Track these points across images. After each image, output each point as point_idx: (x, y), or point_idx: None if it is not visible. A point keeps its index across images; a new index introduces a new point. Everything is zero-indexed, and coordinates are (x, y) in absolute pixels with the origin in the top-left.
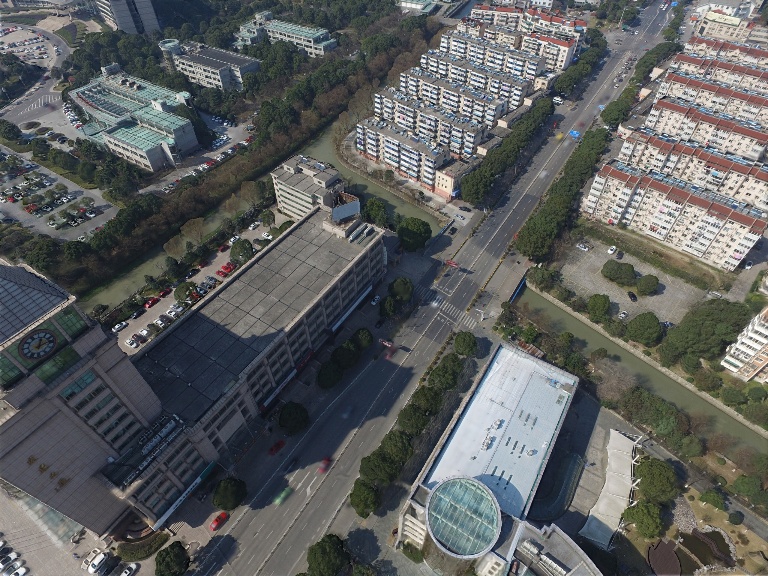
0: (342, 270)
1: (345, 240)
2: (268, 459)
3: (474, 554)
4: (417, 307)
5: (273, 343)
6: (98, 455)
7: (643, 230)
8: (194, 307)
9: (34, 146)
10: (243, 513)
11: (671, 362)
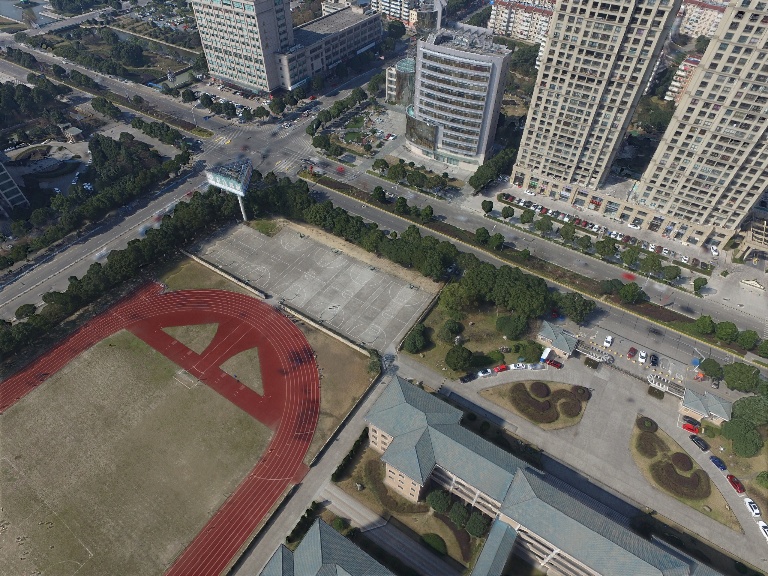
0: (362, 20)
1: (363, 15)
2: (331, 88)
3: (412, 71)
4: (397, 56)
5: (334, 33)
6: (276, 44)
7: (518, 36)
8: (298, 26)
9: (179, 2)
10: (323, 97)
11: (513, 67)
